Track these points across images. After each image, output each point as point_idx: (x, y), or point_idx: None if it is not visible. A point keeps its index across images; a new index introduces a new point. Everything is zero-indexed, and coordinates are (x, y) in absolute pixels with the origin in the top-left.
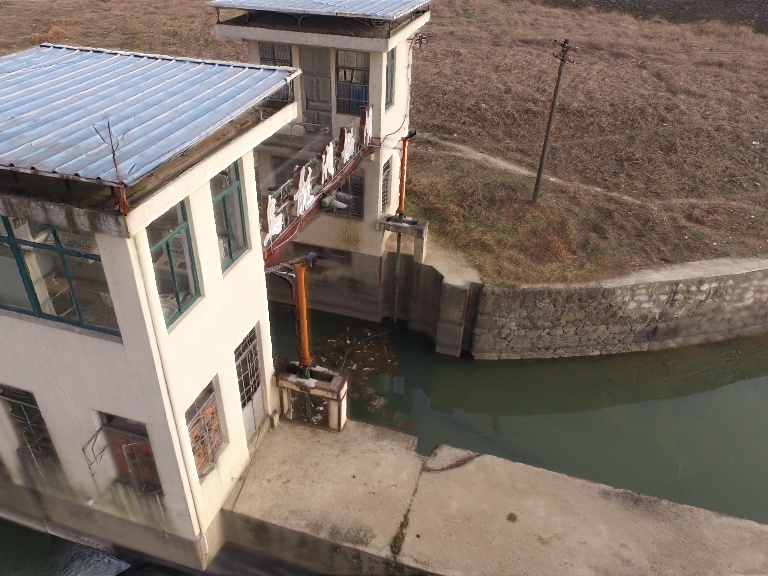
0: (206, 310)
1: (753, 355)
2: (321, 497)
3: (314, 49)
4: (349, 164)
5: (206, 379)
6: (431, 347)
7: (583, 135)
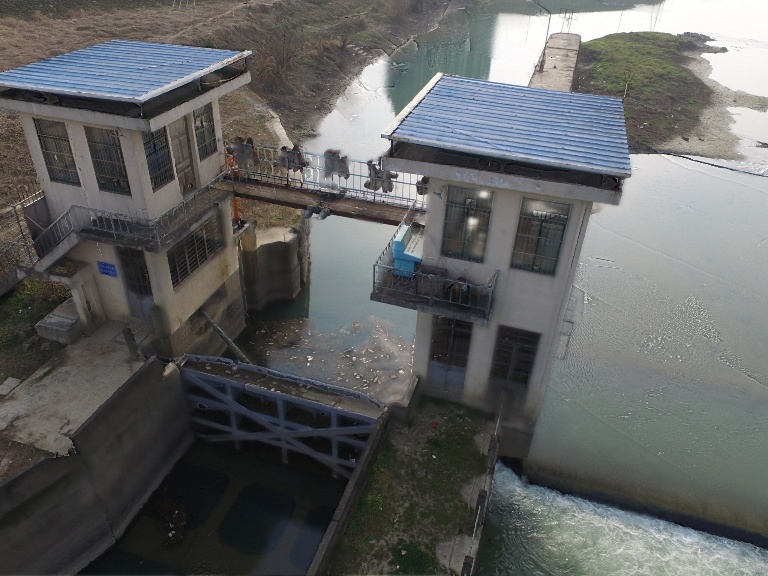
0: None
1: None
2: None
3: None
4: None
5: None
6: (287, 301)
7: None
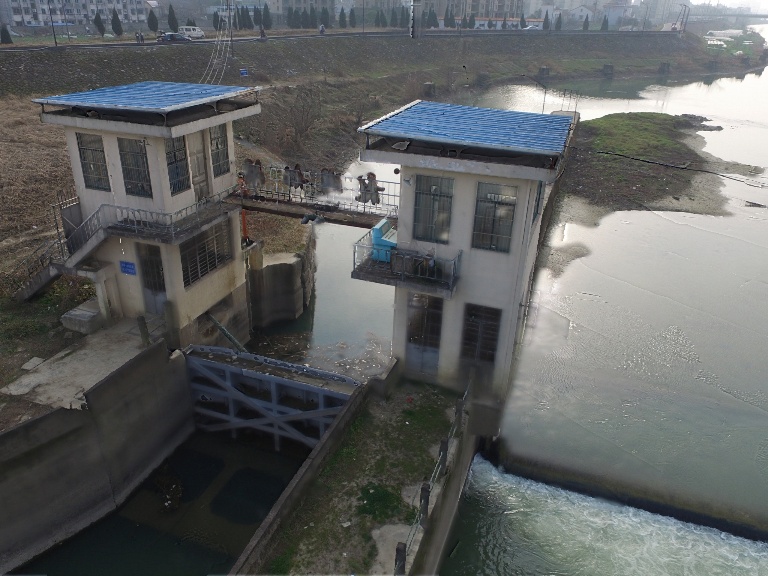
0: None
1: (319, 237)
2: None
3: None
4: None
5: None
6: (289, 321)
7: None
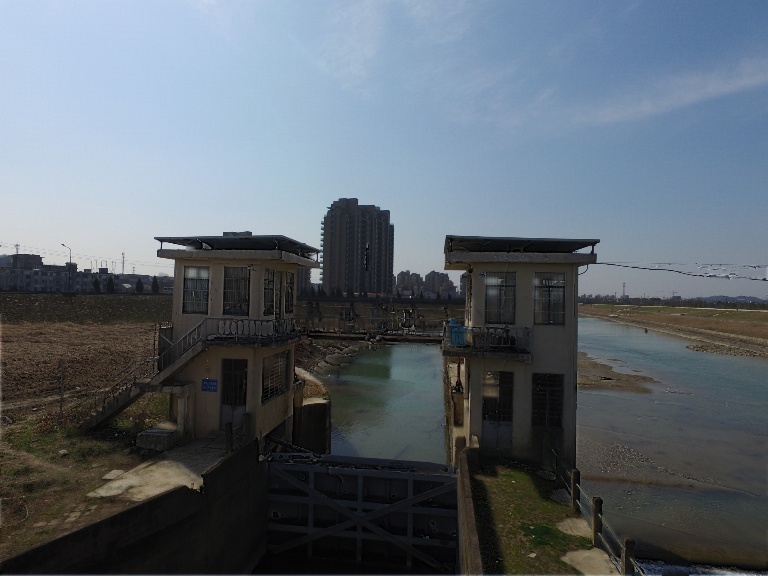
0: None
1: None
2: None
3: (277, 272)
4: None
5: None
6: None
7: None
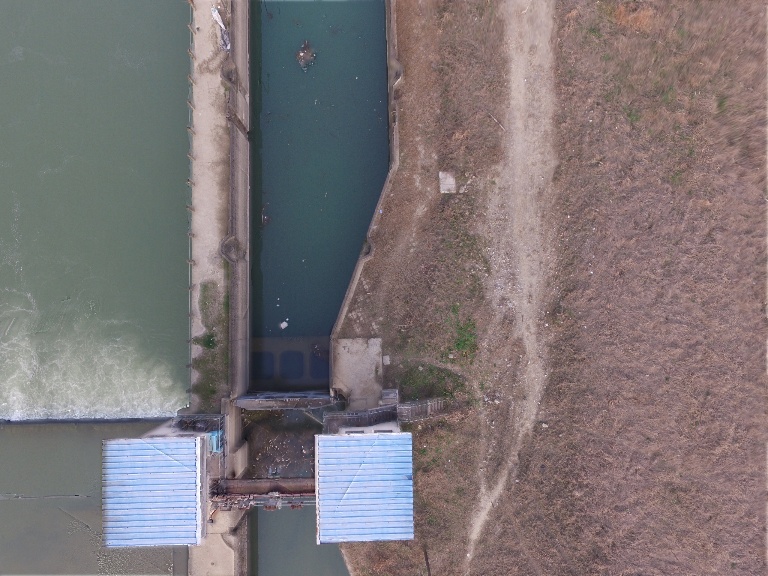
0: None
1: None
2: None
3: None
4: None
5: None
6: None
7: (547, 573)
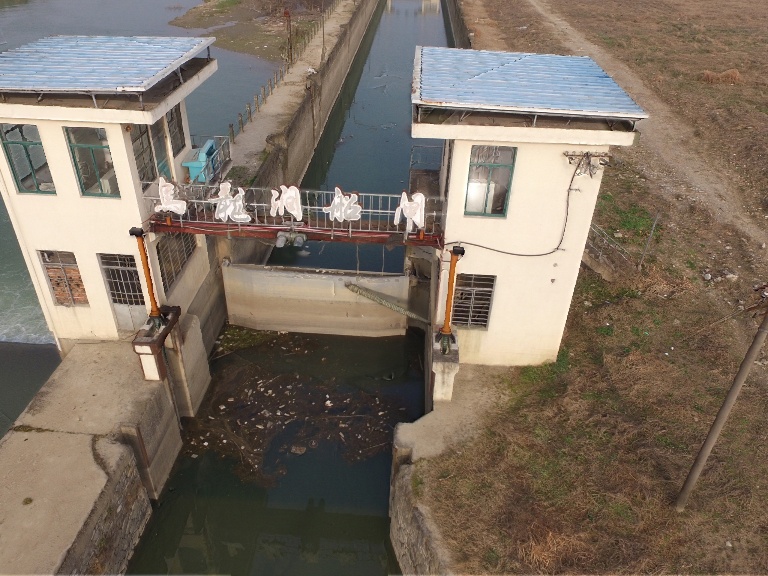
0: (59, 205)
1: None
2: (77, 381)
3: None
4: (375, 234)
5: (60, 246)
6: None
7: None
